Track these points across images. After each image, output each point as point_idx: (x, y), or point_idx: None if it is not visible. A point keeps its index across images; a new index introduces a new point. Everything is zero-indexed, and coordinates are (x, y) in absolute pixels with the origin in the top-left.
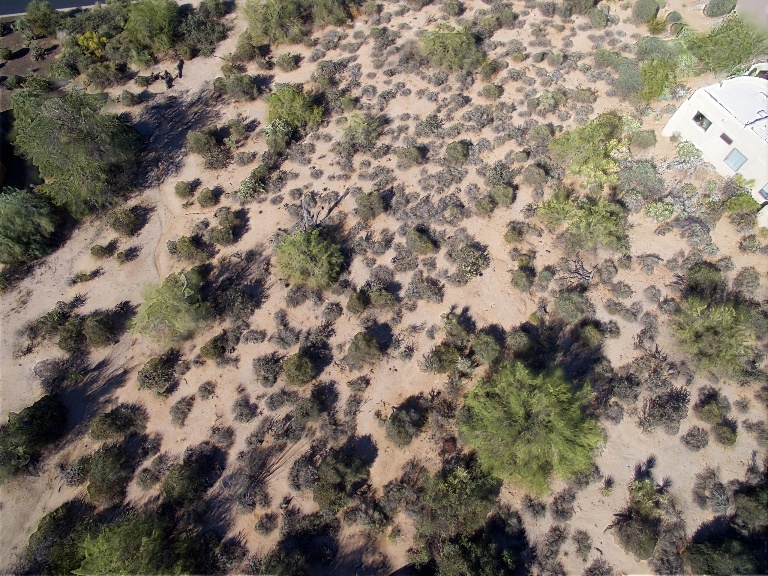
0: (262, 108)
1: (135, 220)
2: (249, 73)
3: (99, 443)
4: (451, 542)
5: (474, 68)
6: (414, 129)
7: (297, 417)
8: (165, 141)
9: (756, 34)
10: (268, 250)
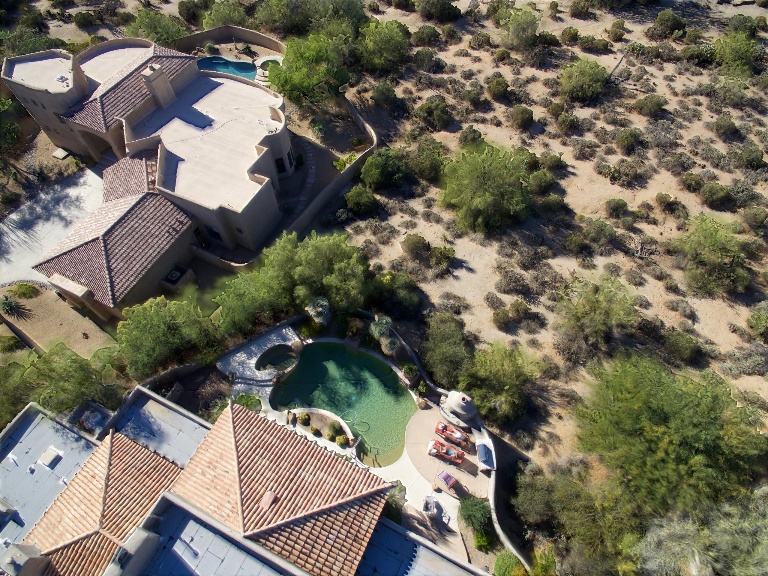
0: None
1: (583, 12)
2: (767, 35)
3: None
4: None
5: None
6: None
7: None
8: None
9: None
10: None
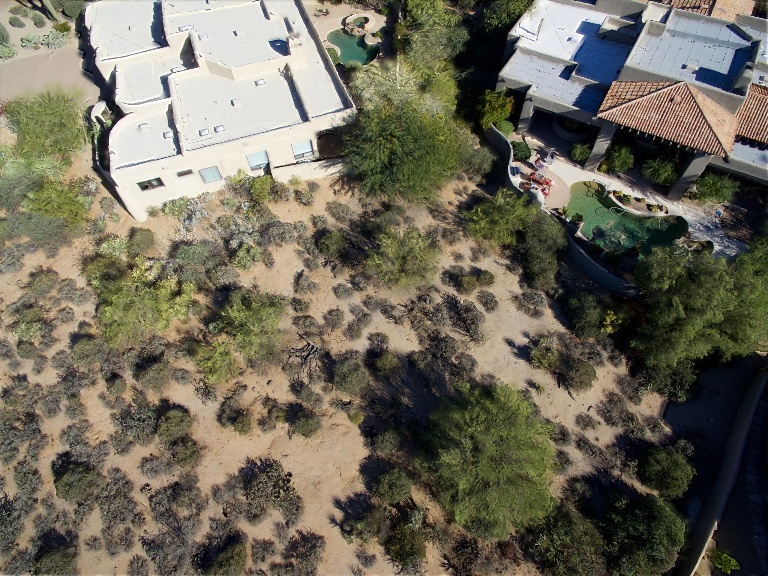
0: None
1: None
2: None
3: None
4: (609, 563)
5: None
6: None
7: None
8: None
9: (37, 97)
10: None
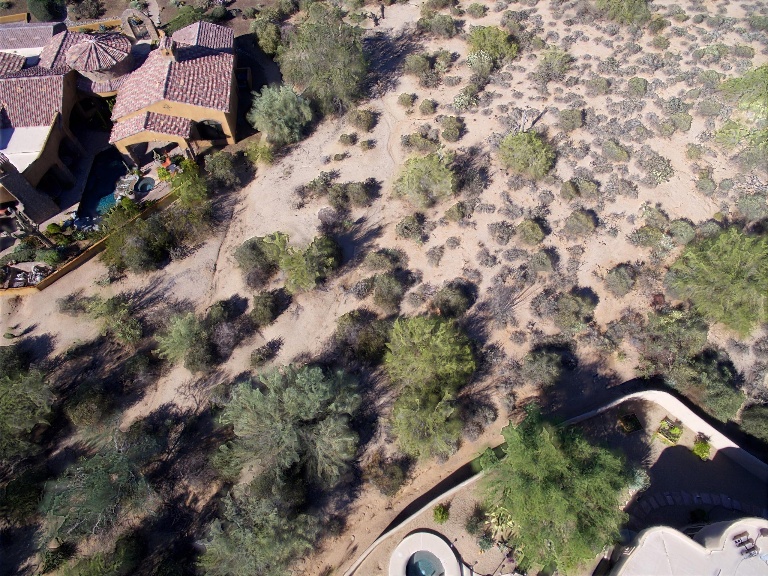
0: (459, 44)
1: (371, 119)
2: None
3: (371, 273)
4: None
5: (642, 24)
6: (596, 67)
7: (534, 265)
8: (380, 65)
9: None
10: (486, 148)
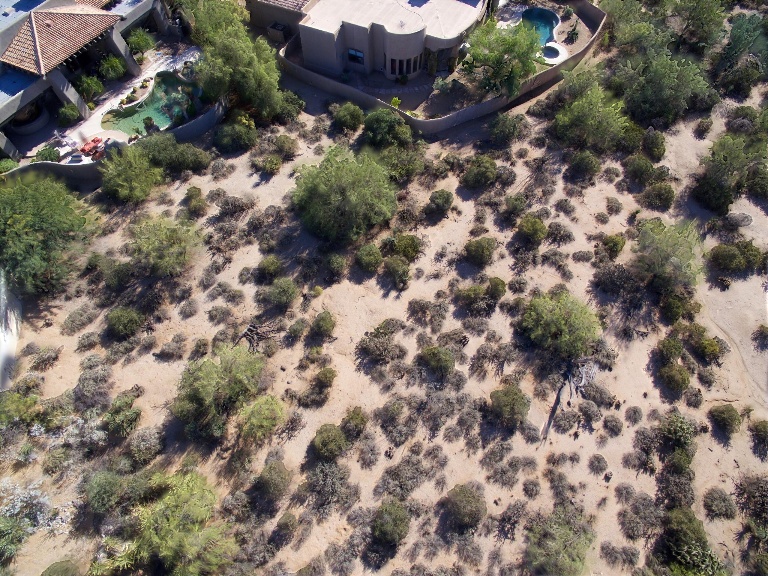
0: None
1: None
2: None
3: None
4: None
5: None
6: None
7: (523, 198)
8: None
9: None
10: (612, 342)
